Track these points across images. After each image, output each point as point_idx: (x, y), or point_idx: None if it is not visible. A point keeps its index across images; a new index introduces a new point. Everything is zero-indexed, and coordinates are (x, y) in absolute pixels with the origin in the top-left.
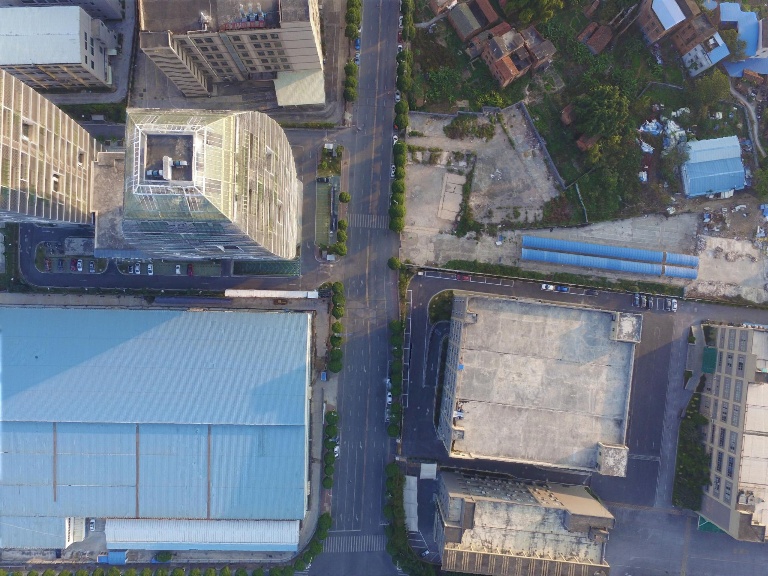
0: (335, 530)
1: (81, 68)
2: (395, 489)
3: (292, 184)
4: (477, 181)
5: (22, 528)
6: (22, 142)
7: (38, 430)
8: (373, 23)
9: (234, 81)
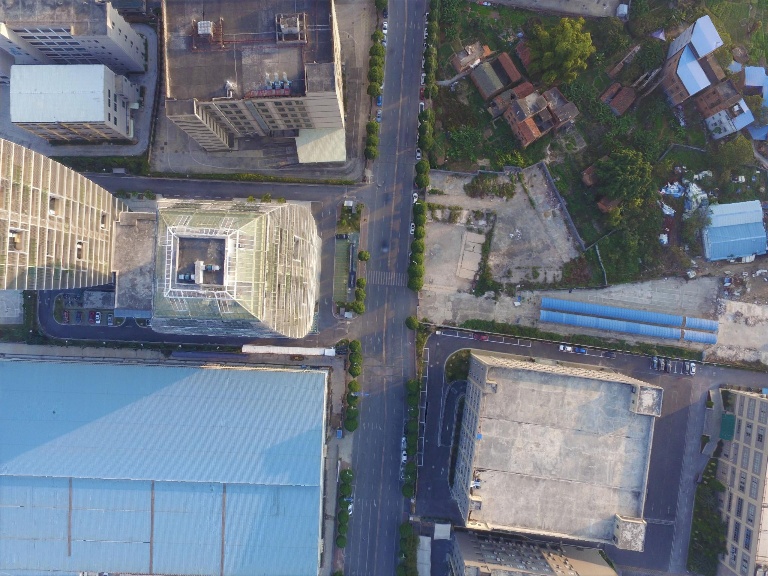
0: None
1: (104, 125)
2: (409, 550)
3: (314, 254)
4: (496, 240)
5: None
6: (49, 218)
7: (54, 485)
8: (395, 80)
9: (255, 136)
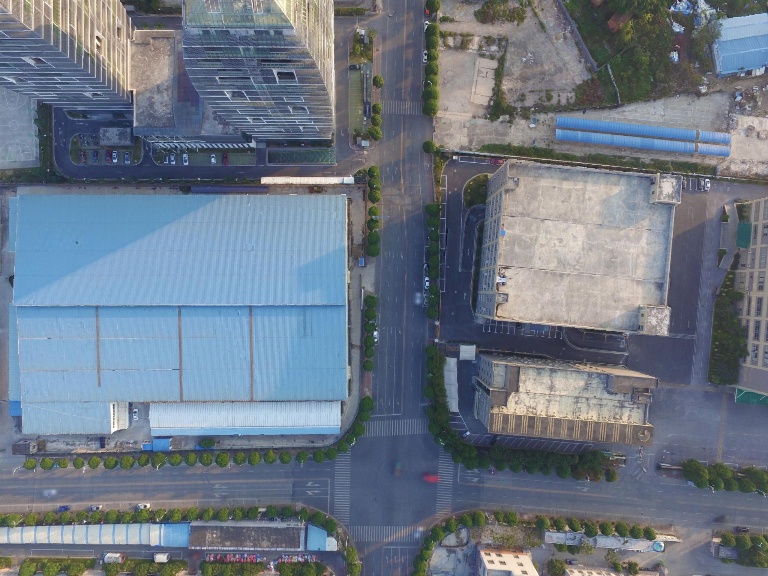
0: (376, 415)
1: None
2: (436, 368)
3: None
4: (509, 65)
5: (67, 414)
6: None
7: (81, 315)
8: None
9: None
